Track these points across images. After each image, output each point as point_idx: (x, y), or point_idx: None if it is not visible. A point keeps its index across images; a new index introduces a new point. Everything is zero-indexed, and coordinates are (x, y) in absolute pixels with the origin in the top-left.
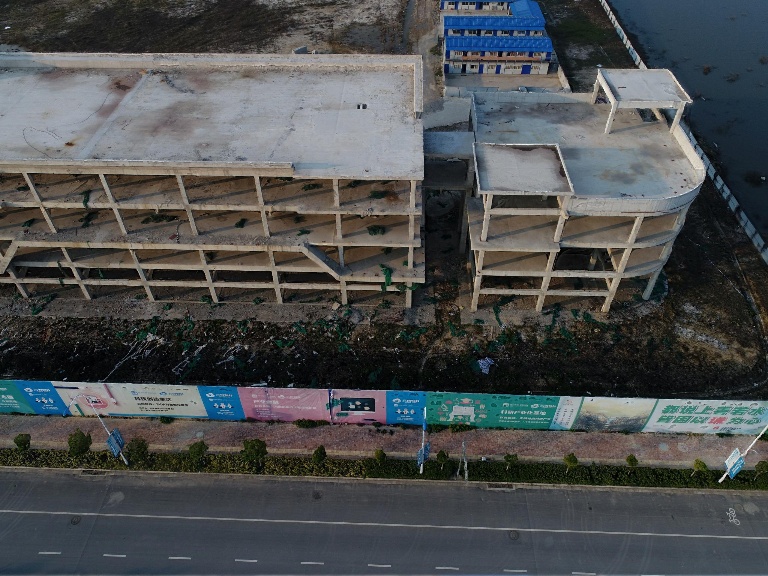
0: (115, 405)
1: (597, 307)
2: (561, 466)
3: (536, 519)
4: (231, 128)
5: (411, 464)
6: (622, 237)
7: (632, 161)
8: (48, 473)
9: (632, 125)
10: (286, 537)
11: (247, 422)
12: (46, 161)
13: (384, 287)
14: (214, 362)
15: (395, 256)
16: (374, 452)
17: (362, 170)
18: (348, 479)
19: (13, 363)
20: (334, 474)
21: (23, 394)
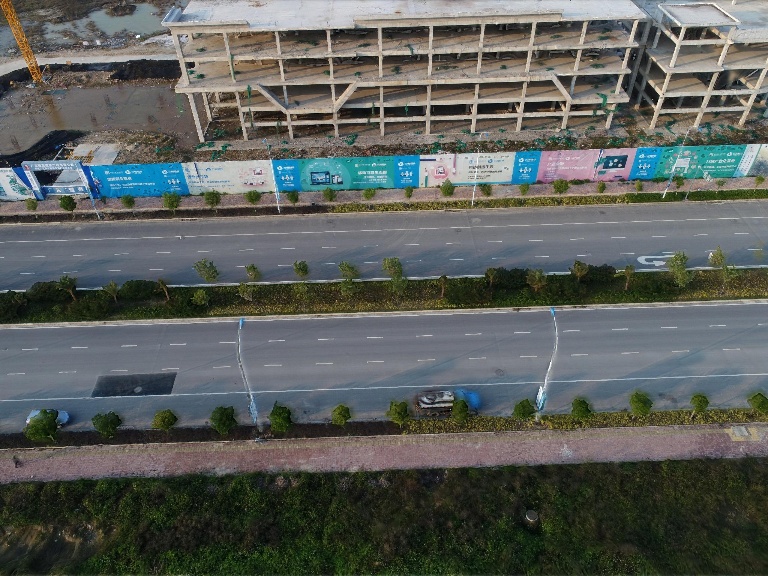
0: (453, 175)
1: (735, 123)
2: (749, 190)
3: (743, 214)
4: (497, 1)
5: (655, 194)
6: (761, 62)
7: (759, 16)
8: (423, 213)
9: (748, 0)
10: (595, 229)
11: (536, 184)
12: (403, 15)
13: (595, 111)
14: None
15: (603, 89)
16: (627, 192)
17: (605, 15)
18: (617, 205)
19: None
20: (608, 202)
21: (395, 169)
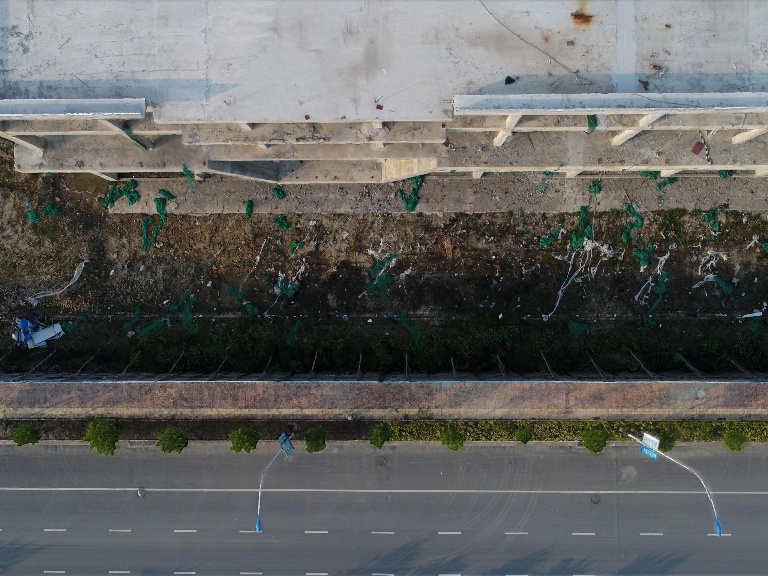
0: None
1: None
2: None
3: None
4: None
5: None
6: None
7: None
8: (540, 446)
9: None
10: None
11: None
12: (601, 111)
13: None
14: (689, 285)
15: None
16: None
17: None
18: None
19: (427, 299)
20: None
21: None
